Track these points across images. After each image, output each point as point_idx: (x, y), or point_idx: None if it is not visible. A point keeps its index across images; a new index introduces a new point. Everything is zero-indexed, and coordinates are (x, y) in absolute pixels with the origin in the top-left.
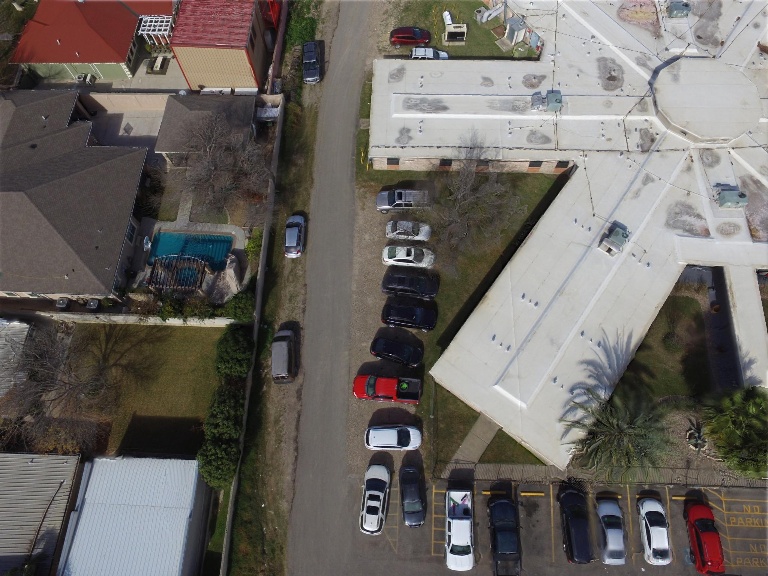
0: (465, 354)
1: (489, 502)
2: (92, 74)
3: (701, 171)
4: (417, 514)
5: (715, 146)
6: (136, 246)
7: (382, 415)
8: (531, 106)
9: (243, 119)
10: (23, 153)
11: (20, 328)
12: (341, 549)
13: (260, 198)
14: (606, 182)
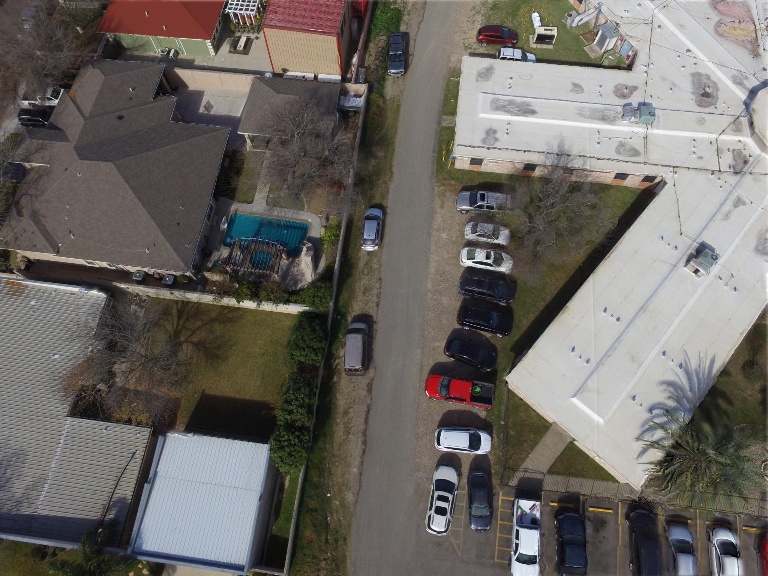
0: (543, 363)
1: (557, 514)
2: (175, 49)
3: None
4: (484, 519)
5: None
6: (212, 225)
7: (452, 416)
8: (622, 117)
9: (328, 107)
10: (110, 123)
11: (98, 297)
12: (404, 546)
13: (339, 188)
14: (695, 201)
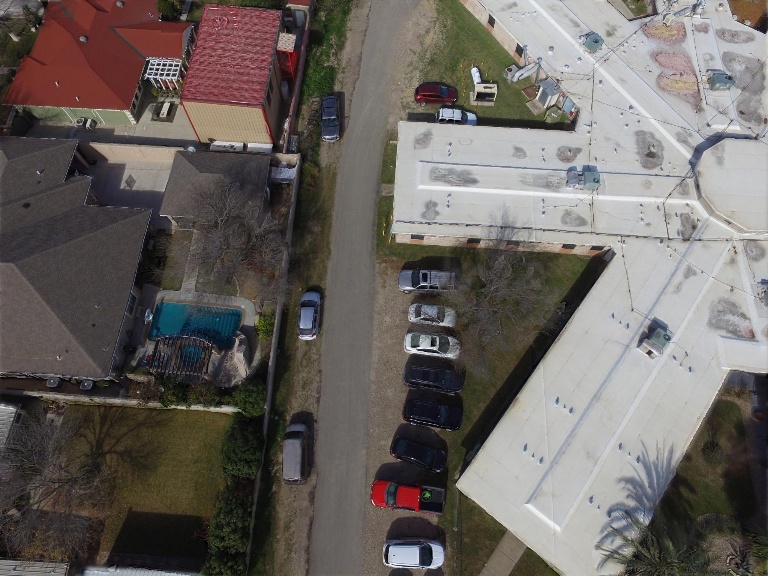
0: (494, 465)
1: None
2: (92, 118)
3: (745, 265)
4: None
5: (760, 237)
6: (136, 317)
7: (401, 525)
8: (567, 183)
9: (257, 183)
10: (14, 214)
11: (5, 413)
12: None
13: (273, 270)
14: (645, 272)
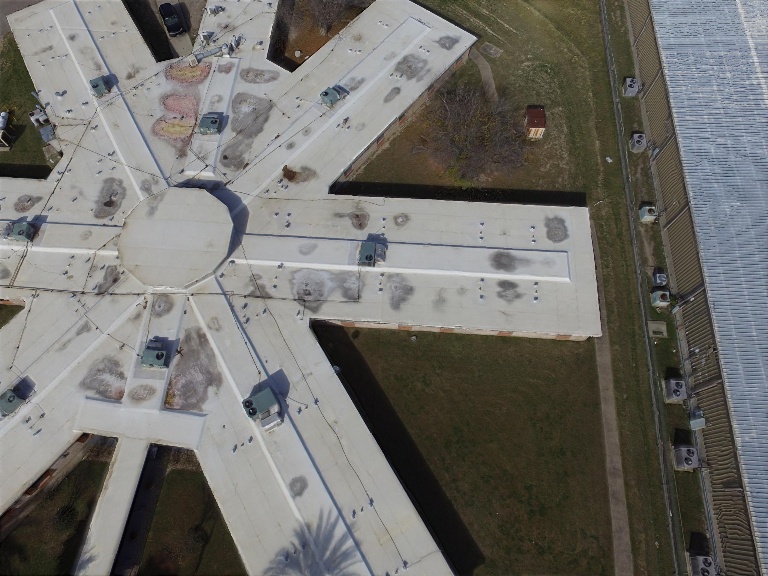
0: None
1: None
2: None
3: (145, 321)
4: None
5: (172, 291)
6: None
7: None
8: None
9: None
10: None
11: None
12: None
13: None
14: (43, 328)
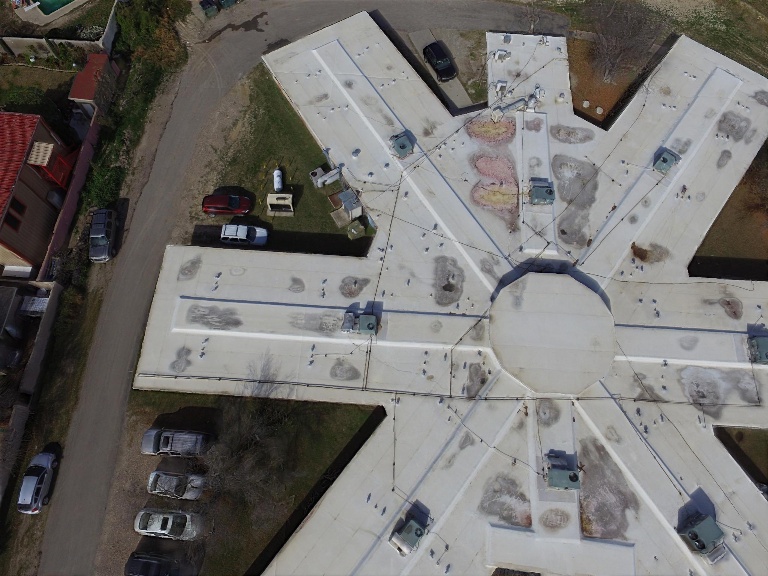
0: None
1: None
2: None
3: (534, 431)
4: None
5: (556, 395)
6: None
7: None
8: (341, 327)
9: None
10: None
11: None
12: None
13: (7, 424)
14: (416, 440)
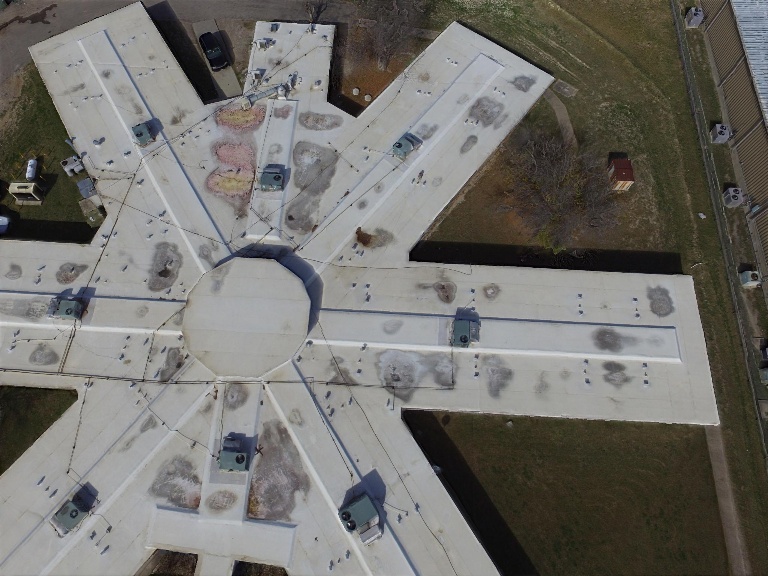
0: None
1: None
2: None
3: (218, 414)
4: None
5: (246, 379)
6: None
7: None
8: None
9: None
10: None
11: None
12: None
13: None
14: (101, 424)
